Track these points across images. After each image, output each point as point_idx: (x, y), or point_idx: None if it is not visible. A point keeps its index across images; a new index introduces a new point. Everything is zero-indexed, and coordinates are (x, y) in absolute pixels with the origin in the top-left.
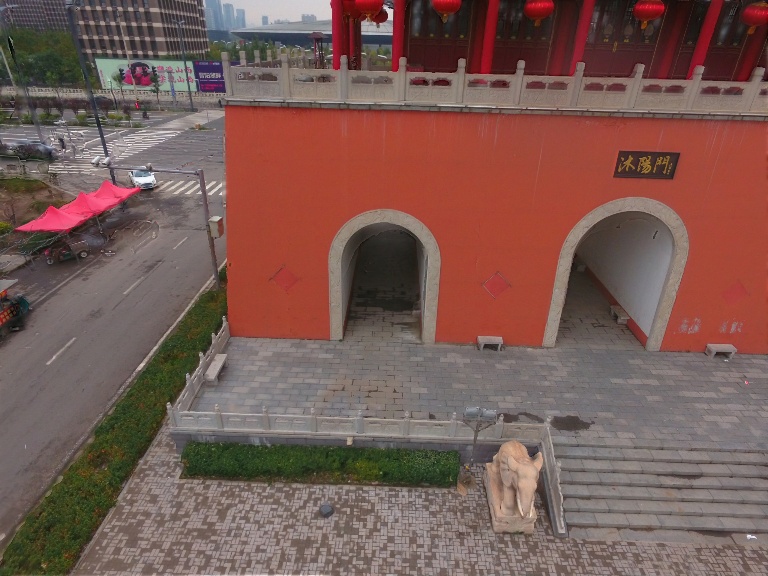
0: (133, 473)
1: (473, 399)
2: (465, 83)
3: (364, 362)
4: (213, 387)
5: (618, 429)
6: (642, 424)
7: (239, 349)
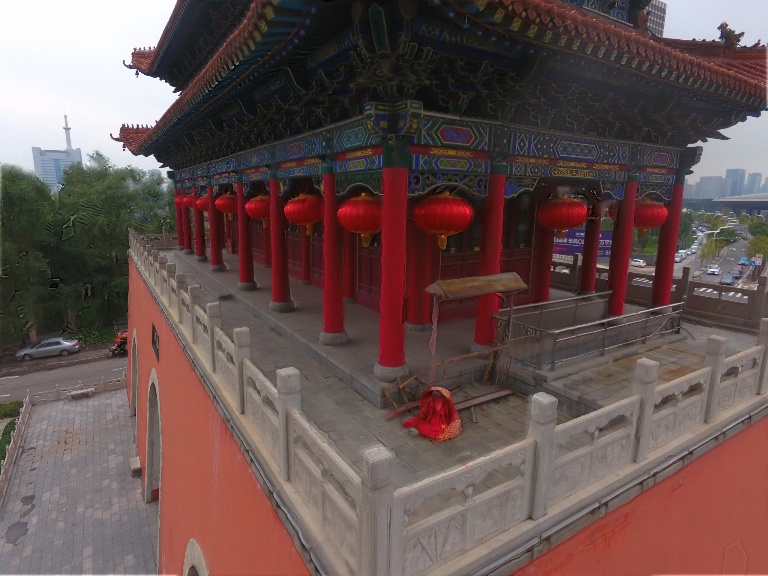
0: (15, 417)
1: (55, 480)
2: (141, 253)
3: (103, 430)
4: (68, 400)
5: (3, 561)
6: (9, 575)
7: (112, 394)
